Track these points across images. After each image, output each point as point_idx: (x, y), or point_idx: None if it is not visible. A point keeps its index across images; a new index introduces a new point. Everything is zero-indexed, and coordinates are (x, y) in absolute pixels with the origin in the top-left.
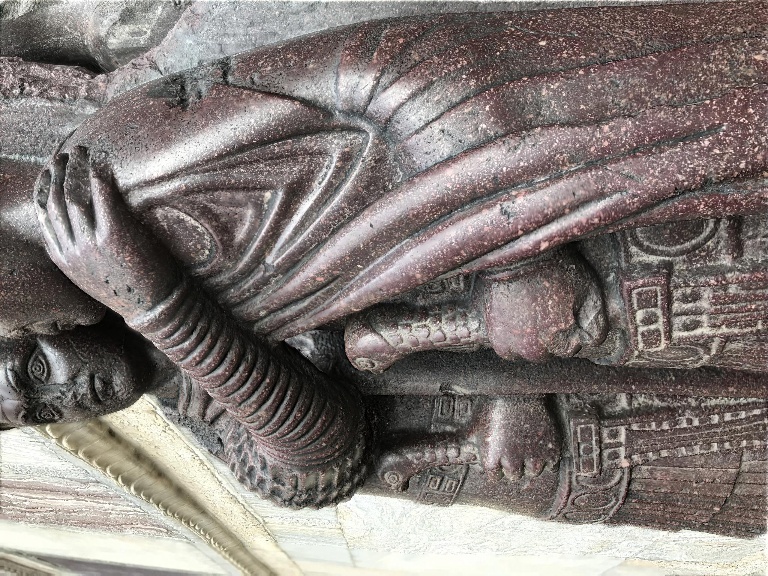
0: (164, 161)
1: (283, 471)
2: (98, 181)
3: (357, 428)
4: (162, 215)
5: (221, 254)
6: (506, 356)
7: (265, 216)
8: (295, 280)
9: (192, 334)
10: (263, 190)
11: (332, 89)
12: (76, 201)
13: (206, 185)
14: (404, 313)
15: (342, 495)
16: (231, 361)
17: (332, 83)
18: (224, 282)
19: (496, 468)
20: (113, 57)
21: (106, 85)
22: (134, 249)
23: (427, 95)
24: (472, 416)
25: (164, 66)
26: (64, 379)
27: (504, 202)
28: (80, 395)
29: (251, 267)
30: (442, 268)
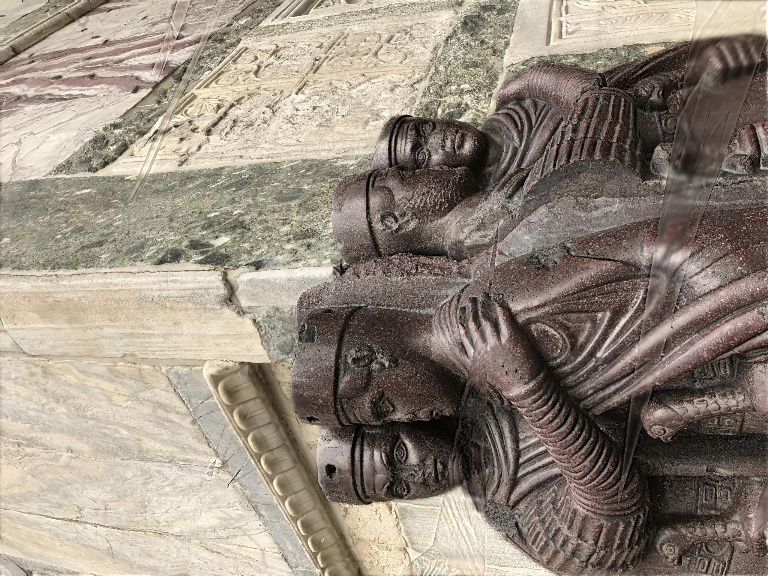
0: (540, 297)
1: (592, 522)
2: (502, 309)
3: (645, 494)
4: (534, 328)
5: (569, 351)
6: (767, 415)
7: (598, 328)
8: (617, 366)
9: (549, 402)
10: (597, 312)
11: (639, 255)
12: (489, 320)
13: (564, 309)
14: (686, 394)
15: (627, 564)
16: (571, 422)
17: (639, 251)
18: (567, 371)
19: (761, 539)
20: (465, 250)
21: (469, 265)
22: (522, 346)
23: (701, 254)
24: (733, 502)
25: (508, 252)
26: (417, 461)
27: (760, 307)
28: (427, 474)
29: (587, 360)
30: (721, 349)
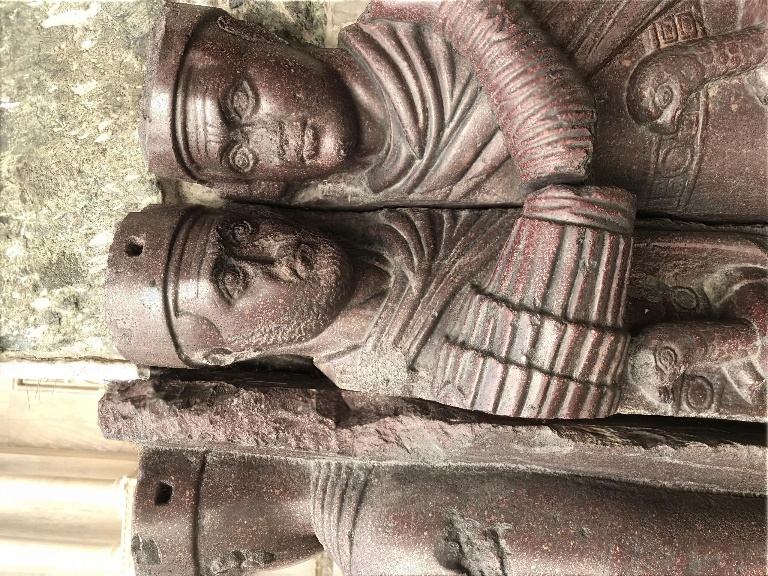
0: None
1: None
2: None
3: None
4: None
5: None
6: None
7: None
8: None
9: None
10: None
11: None
12: None
13: None
14: None
15: None
16: None
17: None
18: None
19: None
20: None
21: (353, 440)
22: None
23: None
24: None
25: (410, 447)
26: None
27: None
28: None
29: None
30: None
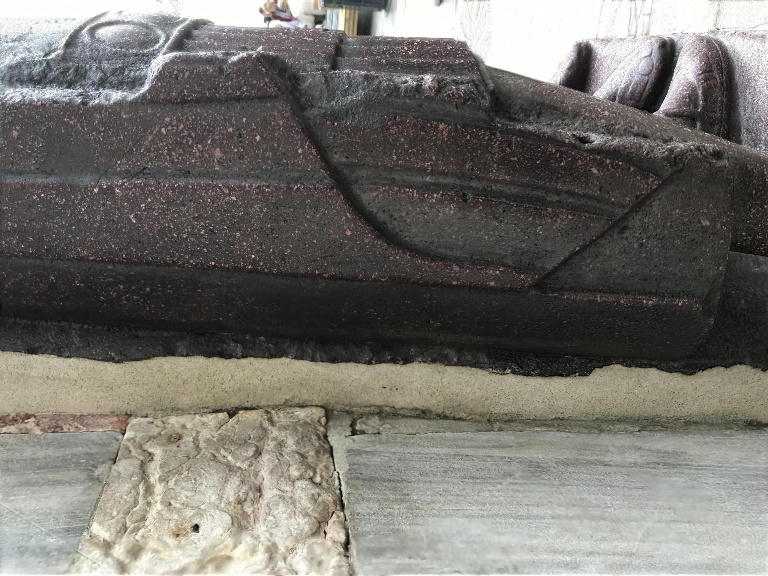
0: None
1: None
2: None
3: None
4: None
5: None
6: None
7: None
8: None
9: None
10: None
11: None
12: None
13: None
14: None
15: None
16: None
17: None
18: None
19: None
20: None
21: None
22: None
23: None
24: None
25: None
26: None
27: None
28: None
29: None
30: None
